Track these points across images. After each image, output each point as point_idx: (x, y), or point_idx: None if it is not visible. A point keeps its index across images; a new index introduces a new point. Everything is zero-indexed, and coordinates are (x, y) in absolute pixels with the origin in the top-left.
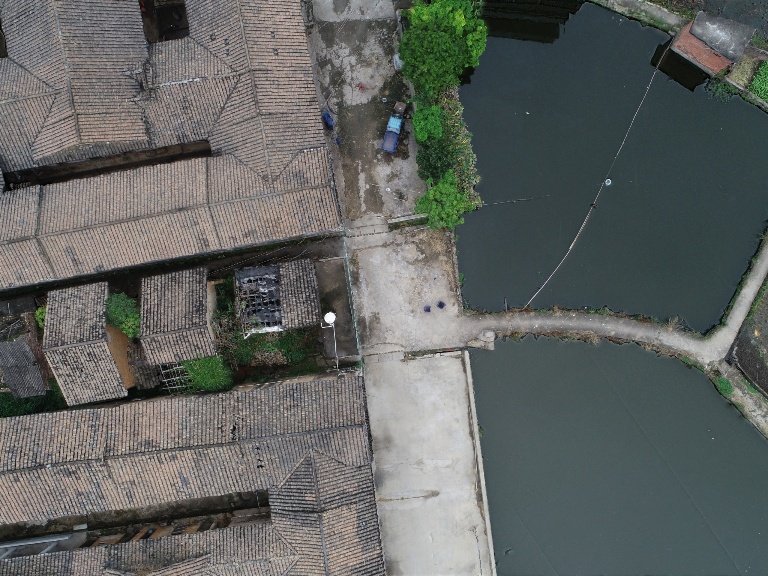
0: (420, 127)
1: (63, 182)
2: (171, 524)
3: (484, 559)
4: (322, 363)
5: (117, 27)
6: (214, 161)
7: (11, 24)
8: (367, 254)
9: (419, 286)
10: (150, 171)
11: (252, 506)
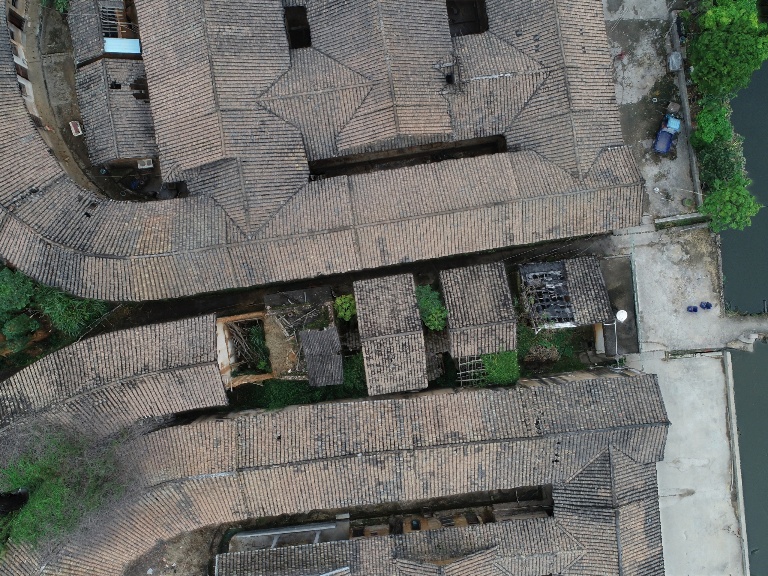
0: (709, 128)
1: (367, 173)
2: (433, 516)
3: (736, 558)
4: (585, 360)
5: (428, 20)
6: (516, 156)
7: (319, 14)
8: (633, 253)
9: (683, 286)
10: (454, 164)
11: (510, 500)
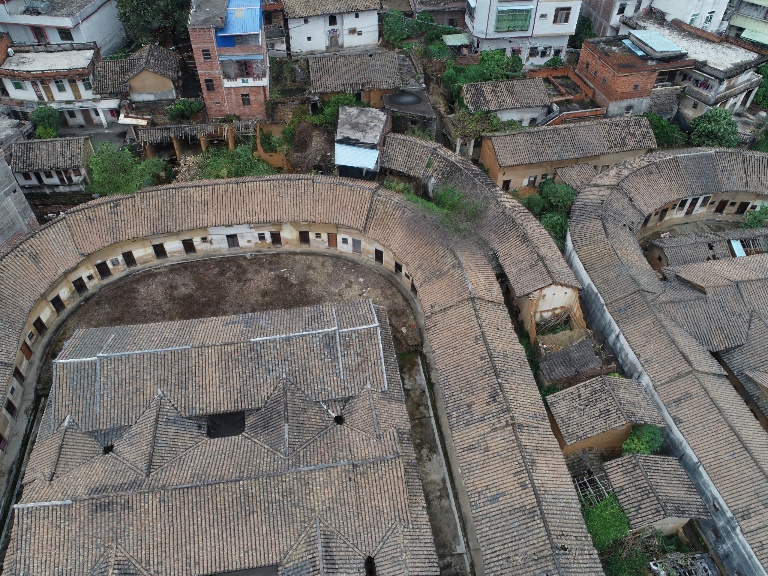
0: None
1: None
2: None
3: None
4: None
5: None
6: None
7: None
8: None
9: None
10: None
11: None
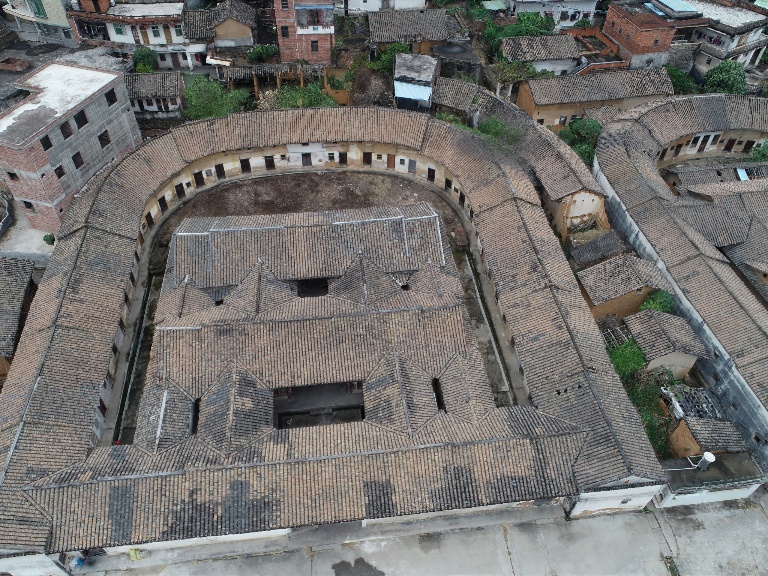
0: None
1: None
2: None
3: None
4: None
5: None
6: None
7: None
8: (761, 517)
9: (752, 575)
10: None
11: None
